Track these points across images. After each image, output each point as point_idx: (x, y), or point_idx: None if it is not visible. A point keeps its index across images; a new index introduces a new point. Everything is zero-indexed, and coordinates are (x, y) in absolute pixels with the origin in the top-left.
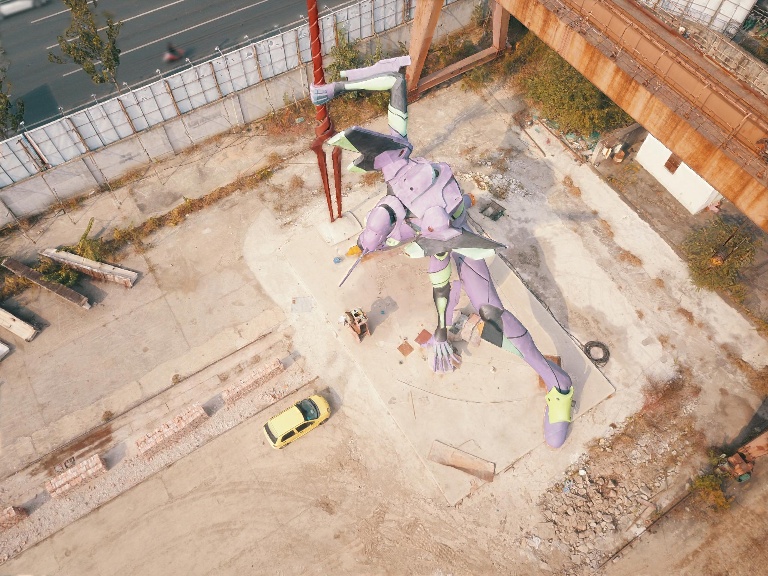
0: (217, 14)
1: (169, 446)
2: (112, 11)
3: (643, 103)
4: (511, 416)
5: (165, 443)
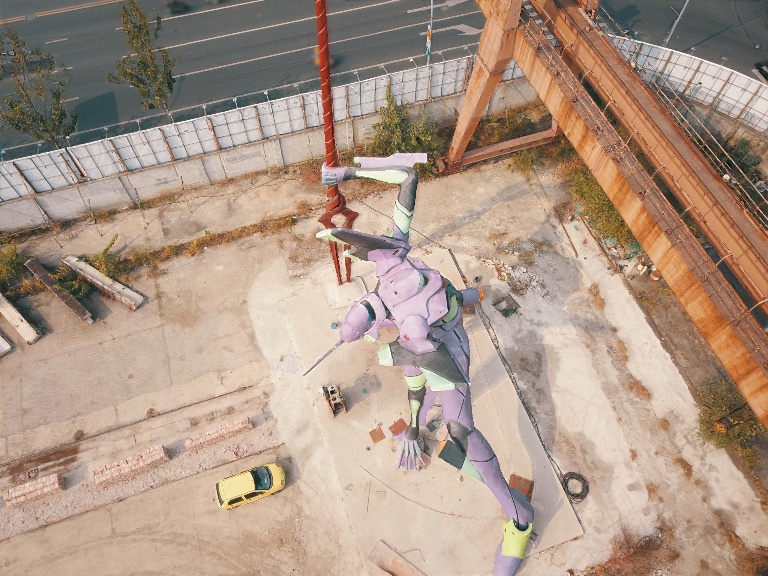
0: (287, 48)
1: (126, 480)
2: (191, 29)
3: (663, 250)
4: (465, 534)
5: (121, 477)
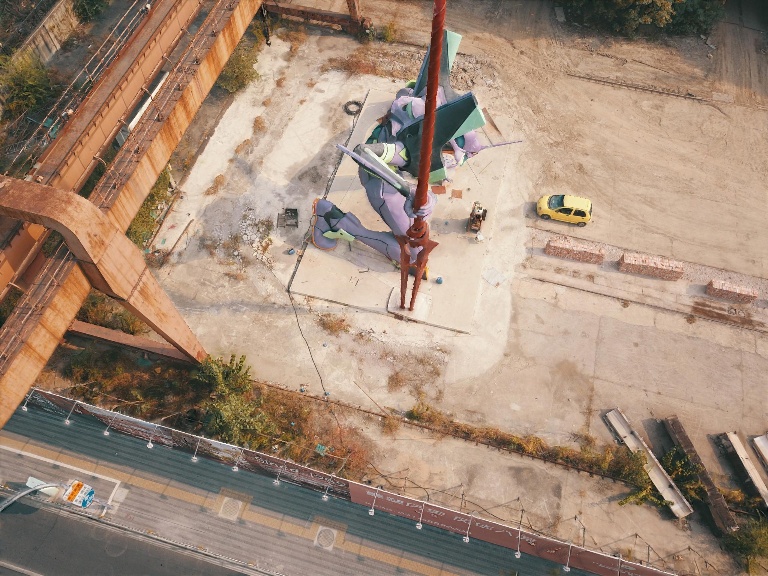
0: None
1: None
2: None
3: None
4: None
5: None
